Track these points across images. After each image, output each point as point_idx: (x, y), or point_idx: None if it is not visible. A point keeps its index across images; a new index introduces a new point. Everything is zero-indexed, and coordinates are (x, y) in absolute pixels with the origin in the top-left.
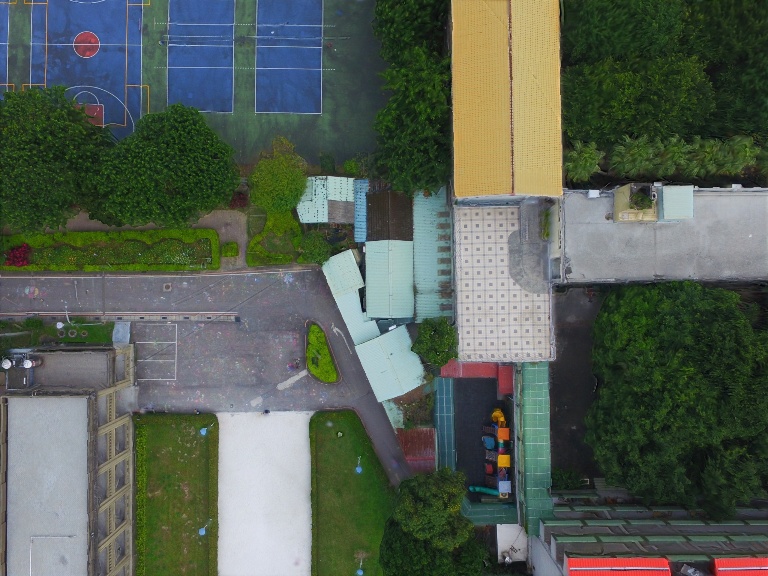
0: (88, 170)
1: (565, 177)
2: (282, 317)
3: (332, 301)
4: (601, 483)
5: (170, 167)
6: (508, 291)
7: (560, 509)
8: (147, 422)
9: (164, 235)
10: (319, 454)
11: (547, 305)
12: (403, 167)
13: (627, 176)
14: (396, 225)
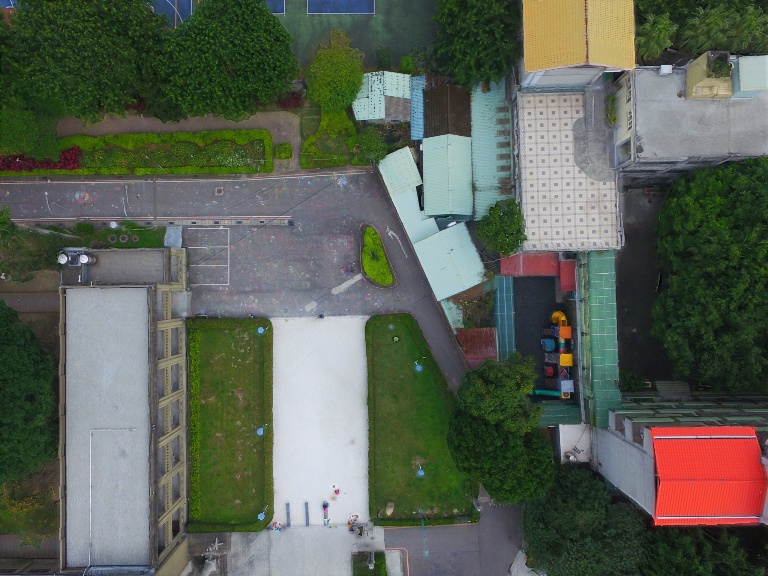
0: (149, 51)
1: (636, 54)
2: (336, 220)
3: (387, 204)
4: (663, 386)
5: (235, 42)
6: (573, 179)
7: (627, 404)
8: (201, 326)
9: (217, 136)
10: (375, 359)
11: (613, 193)
12: (466, 51)
13: (699, 52)
14: (455, 120)
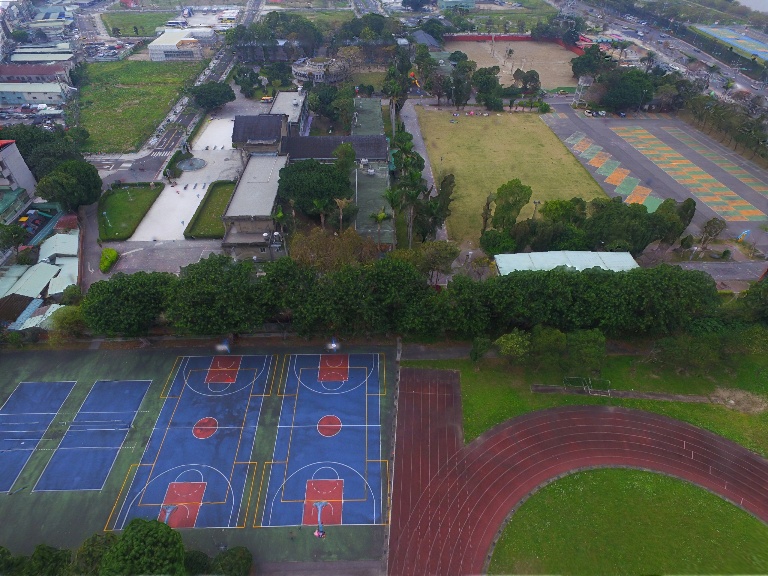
0: None
1: None
2: None
3: (85, 282)
4: None
5: None
6: None
7: None
8: (223, 233)
9: None
10: None
11: None
12: None
13: None
14: None
